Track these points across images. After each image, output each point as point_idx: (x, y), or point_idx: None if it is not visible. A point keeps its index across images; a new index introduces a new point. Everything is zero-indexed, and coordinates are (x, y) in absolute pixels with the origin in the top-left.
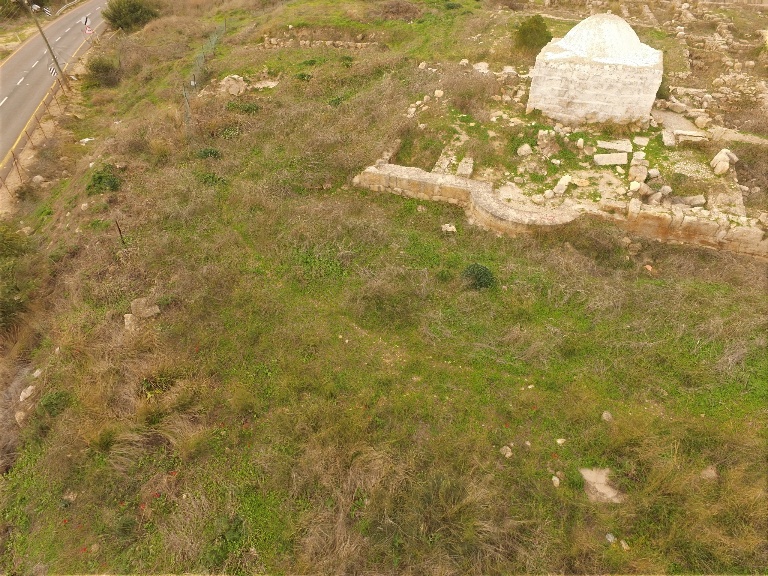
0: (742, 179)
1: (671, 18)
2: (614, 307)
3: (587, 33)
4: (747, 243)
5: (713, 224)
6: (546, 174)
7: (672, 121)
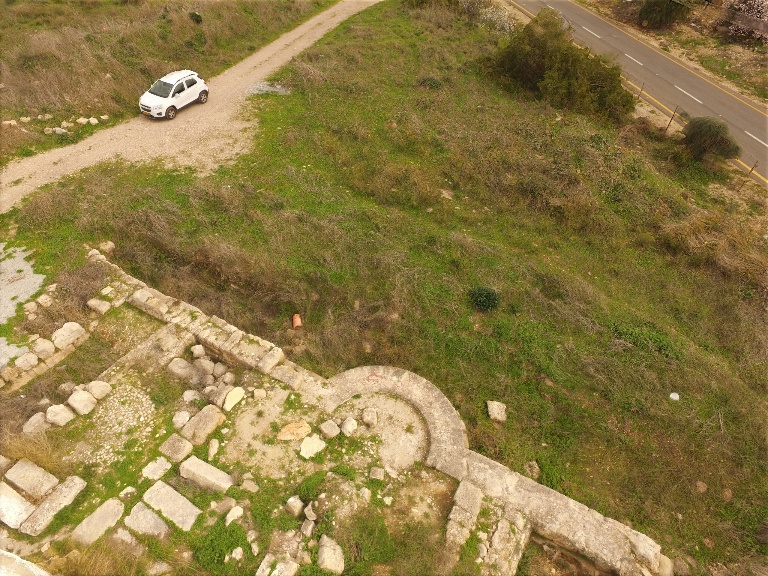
0: None
1: None
2: None
3: None
4: None
5: None
6: (329, 473)
7: None
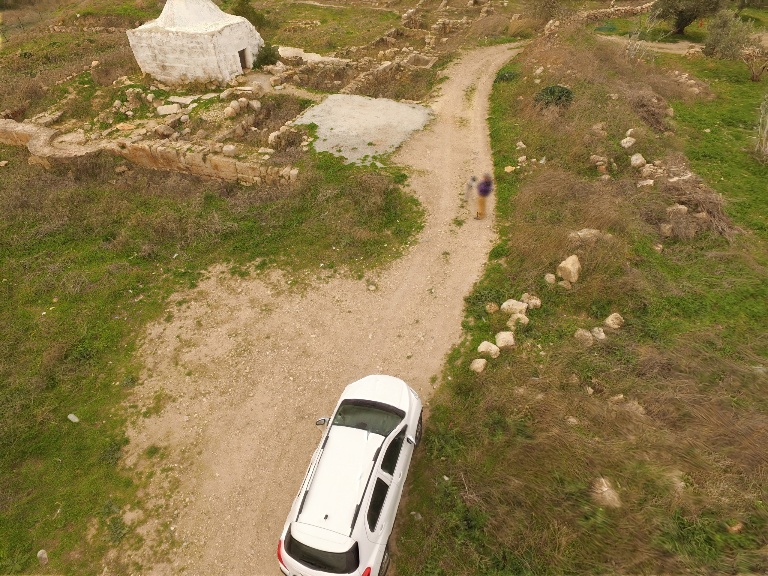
0: (262, 123)
1: (463, 5)
2: (7, 204)
3: (165, 7)
4: (200, 166)
5: (172, 152)
6: (111, 122)
7: (258, 81)
